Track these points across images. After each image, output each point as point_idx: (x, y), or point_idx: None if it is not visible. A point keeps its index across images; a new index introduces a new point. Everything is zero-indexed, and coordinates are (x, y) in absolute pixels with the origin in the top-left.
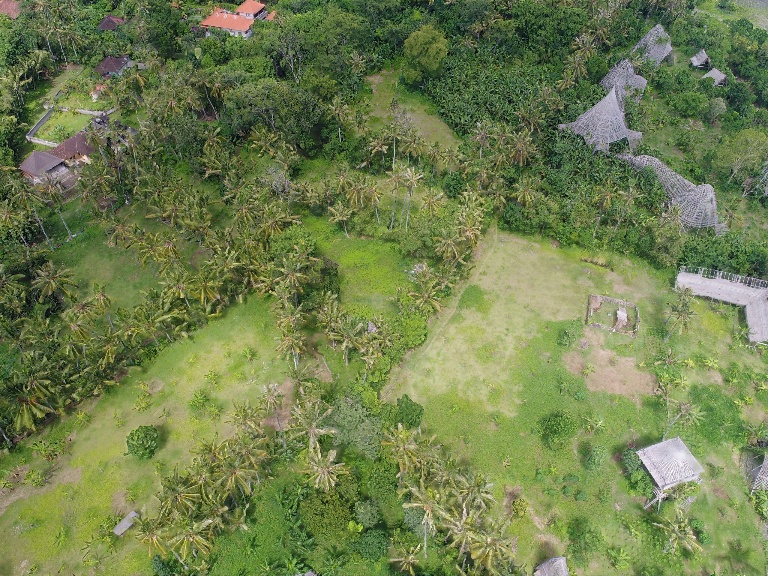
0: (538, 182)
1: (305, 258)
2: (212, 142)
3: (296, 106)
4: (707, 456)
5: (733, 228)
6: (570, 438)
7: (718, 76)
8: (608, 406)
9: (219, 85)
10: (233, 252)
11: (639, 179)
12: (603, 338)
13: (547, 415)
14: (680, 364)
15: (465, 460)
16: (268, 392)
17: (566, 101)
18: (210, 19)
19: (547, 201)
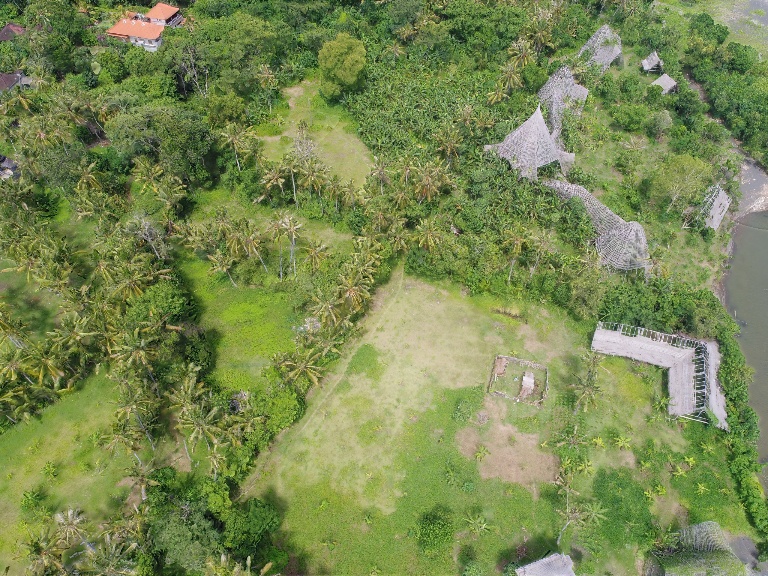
0: (449, 219)
1: (156, 330)
2: (86, 179)
3: (181, 135)
4: (606, 563)
5: (668, 267)
6: (446, 546)
7: (668, 83)
8: (500, 498)
9: (105, 109)
10: (84, 318)
11: (565, 211)
12: (505, 410)
13: (428, 511)
14: (589, 442)
15: (327, 572)
16: (65, 521)
17: (497, 116)
18: (117, 26)
19: (453, 245)
